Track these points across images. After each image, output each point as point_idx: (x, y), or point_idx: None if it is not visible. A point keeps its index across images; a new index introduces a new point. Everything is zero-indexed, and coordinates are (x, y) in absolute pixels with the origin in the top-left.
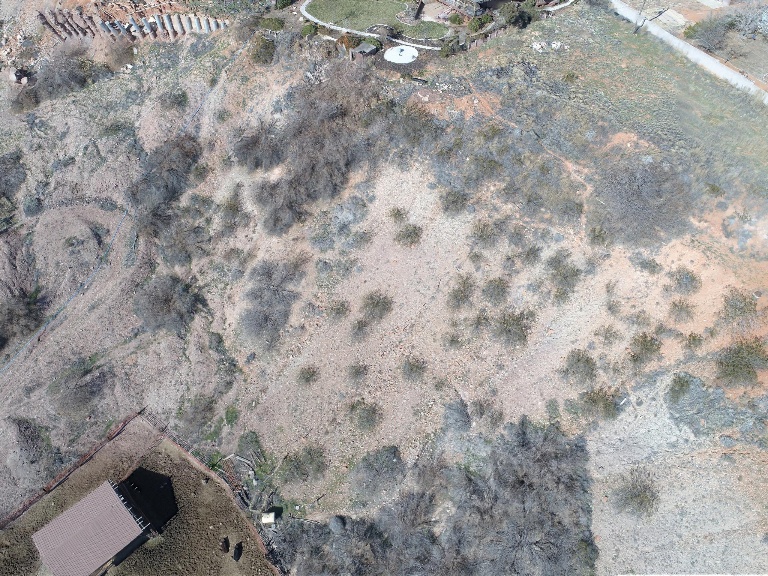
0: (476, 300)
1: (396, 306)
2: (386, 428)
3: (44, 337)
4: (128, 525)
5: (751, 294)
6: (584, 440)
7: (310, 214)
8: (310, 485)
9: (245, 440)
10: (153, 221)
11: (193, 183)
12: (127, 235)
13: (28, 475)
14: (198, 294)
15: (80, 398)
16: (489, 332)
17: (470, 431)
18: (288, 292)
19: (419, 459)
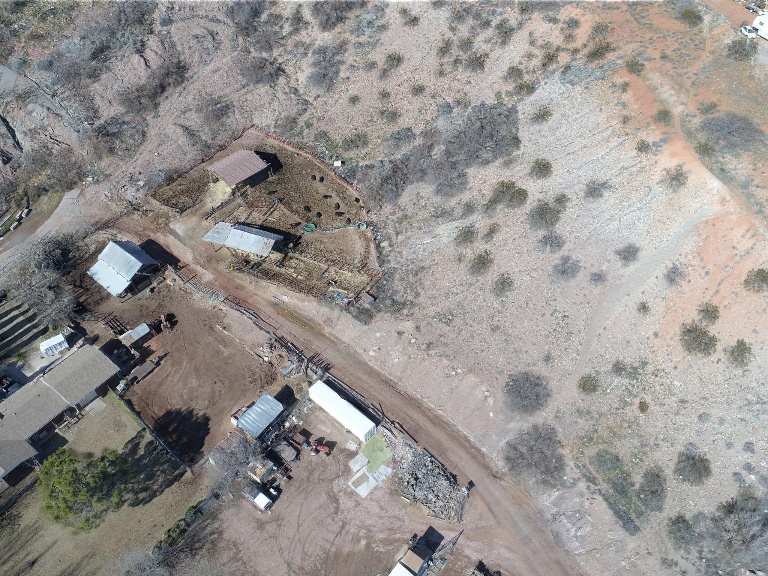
0: (454, 51)
1: (406, 60)
2: (403, 120)
3: (187, 87)
4: (259, 162)
5: (606, 23)
6: (516, 106)
7: (348, 18)
8: (360, 151)
9: (319, 134)
10: (246, 26)
11: (268, 7)
12: (230, 35)
13: (192, 151)
14: (279, 67)
15: (215, 116)
16: (462, 67)
17: (452, 114)
18: (337, 61)
19: (423, 131)
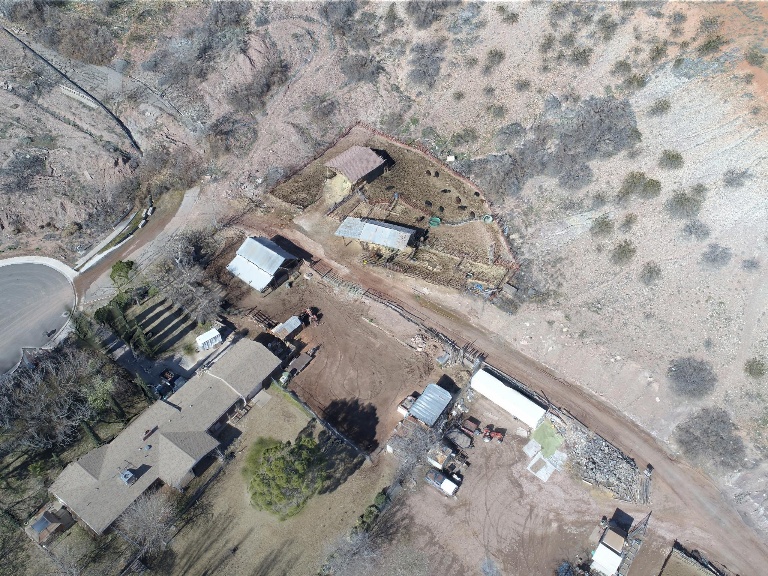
0: (556, 47)
1: (507, 56)
2: (511, 115)
3: (291, 86)
4: (376, 158)
5: (714, 17)
6: (628, 99)
7: (443, 16)
8: (470, 146)
9: (426, 130)
10: (342, 25)
11: (361, 6)
12: (326, 34)
13: (304, 148)
14: (378, 65)
15: (322, 114)
16: (566, 62)
17: (561, 108)
18: (437, 58)
19: (533, 126)
